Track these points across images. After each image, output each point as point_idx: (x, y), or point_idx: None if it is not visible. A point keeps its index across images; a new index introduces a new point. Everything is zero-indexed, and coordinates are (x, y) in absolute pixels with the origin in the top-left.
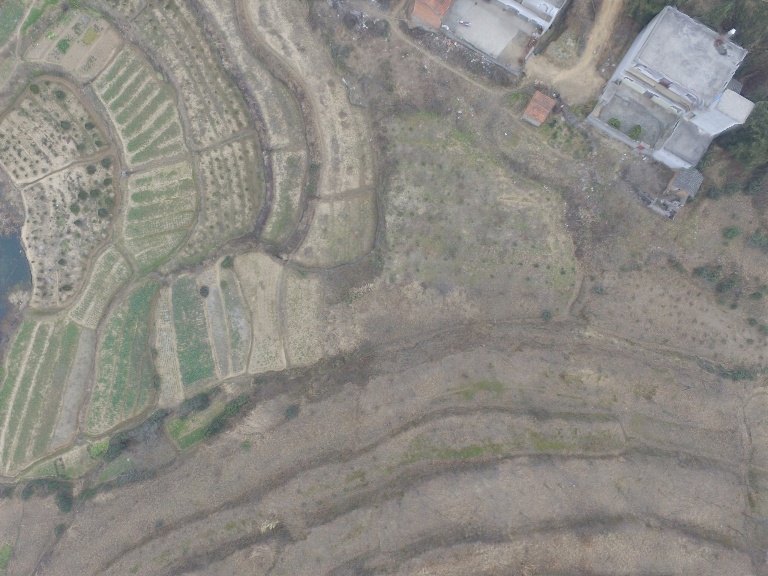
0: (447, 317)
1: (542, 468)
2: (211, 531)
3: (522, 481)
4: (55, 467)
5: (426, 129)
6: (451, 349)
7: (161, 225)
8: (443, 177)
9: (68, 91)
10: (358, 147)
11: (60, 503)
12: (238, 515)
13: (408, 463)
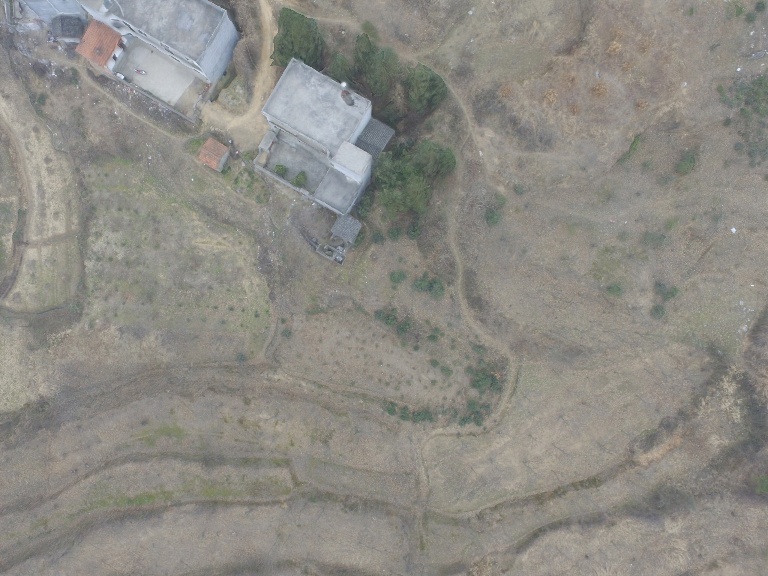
0: (144, 361)
1: (202, 516)
2: None
3: (183, 529)
4: None
5: (121, 175)
6: (139, 395)
7: None
8: (140, 222)
9: None
10: (64, 192)
11: None
12: None
13: (88, 510)
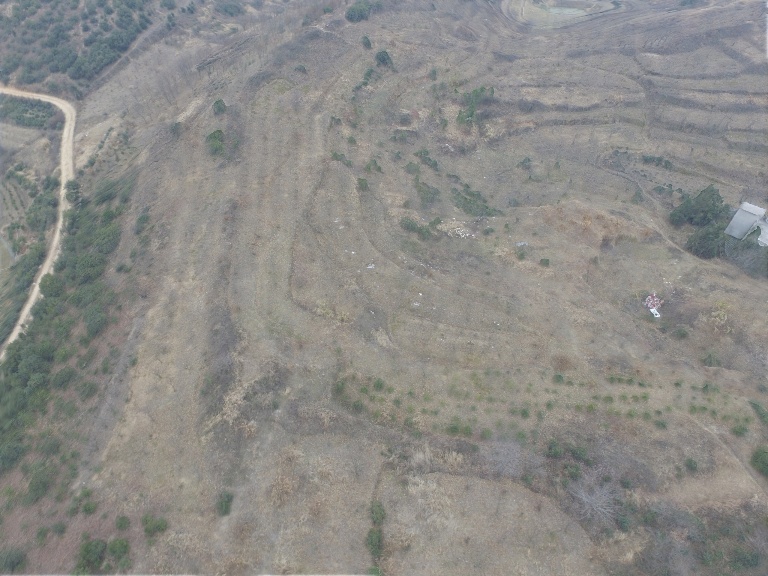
0: None
1: None
2: None
3: None
4: None
5: None
6: None
7: None
8: None
9: None
10: None
11: None
12: None
13: None
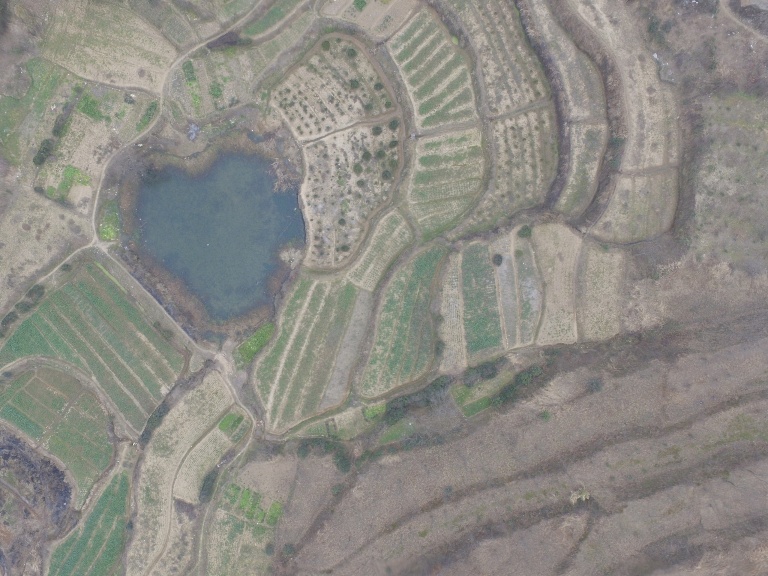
0: (753, 300)
1: None
2: (509, 499)
3: None
4: (327, 427)
5: (744, 109)
6: (765, 332)
7: (447, 191)
8: (757, 159)
9: (358, 50)
10: (664, 124)
11: (340, 463)
12: (540, 485)
13: (725, 443)
